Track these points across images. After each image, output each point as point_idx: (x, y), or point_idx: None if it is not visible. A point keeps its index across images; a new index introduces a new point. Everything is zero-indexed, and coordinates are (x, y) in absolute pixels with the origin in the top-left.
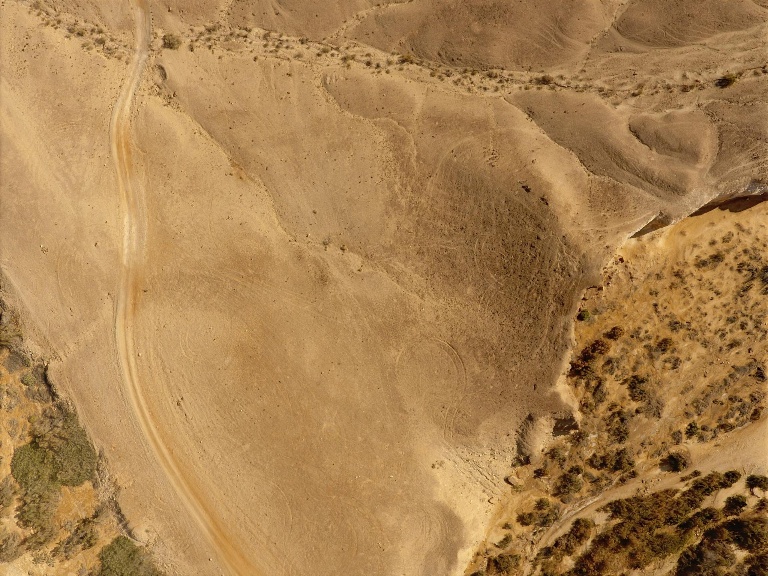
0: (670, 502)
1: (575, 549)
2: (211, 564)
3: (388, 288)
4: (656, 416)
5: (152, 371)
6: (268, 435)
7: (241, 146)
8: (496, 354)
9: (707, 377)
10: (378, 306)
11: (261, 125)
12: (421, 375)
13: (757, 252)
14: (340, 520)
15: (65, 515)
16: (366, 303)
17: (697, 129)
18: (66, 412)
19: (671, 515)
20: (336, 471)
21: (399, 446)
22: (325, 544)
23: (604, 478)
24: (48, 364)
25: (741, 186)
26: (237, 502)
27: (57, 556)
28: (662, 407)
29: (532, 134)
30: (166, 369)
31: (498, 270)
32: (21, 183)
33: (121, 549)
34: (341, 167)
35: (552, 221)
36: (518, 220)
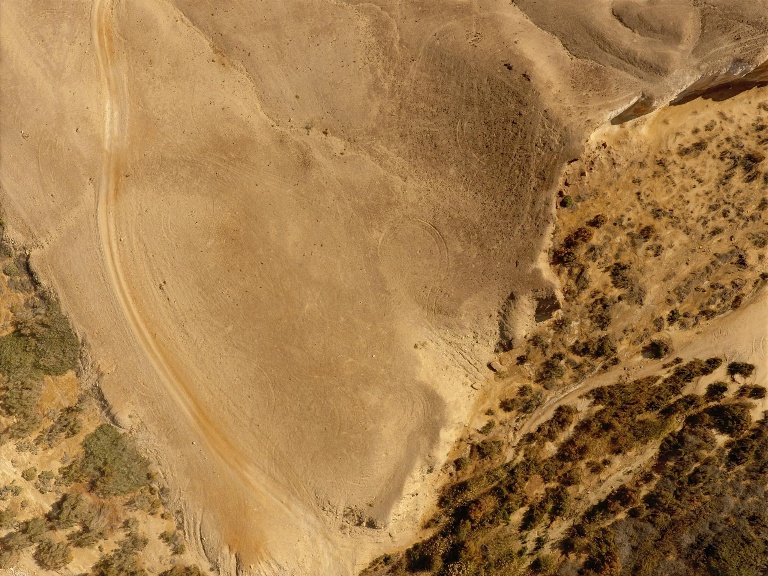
0: (652, 388)
1: (557, 435)
2: (194, 448)
3: (371, 171)
4: (638, 303)
5: (134, 256)
6: (250, 316)
7: (223, 33)
8: (478, 233)
9: (689, 265)
10: (361, 189)
11: (243, 12)
12: (403, 256)
13: (739, 140)
14: (323, 399)
15: (48, 404)
16: (349, 186)
17: (680, 11)
18: (48, 301)
19: (653, 400)
20: (318, 351)
21: (381, 326)
22: (308, 424)
23: (586, 364)
24: (30, 252)
25: (723, 66)
26: (220, 385)
27: (40, 444)
28: (644, 294)
29: (515, 18)
30: (148, 253)
31: (480, 149)
32: (1, 69)
33: (104, 436)
34: (324, 52)
35: (534, 96)
36: (500, 98)
